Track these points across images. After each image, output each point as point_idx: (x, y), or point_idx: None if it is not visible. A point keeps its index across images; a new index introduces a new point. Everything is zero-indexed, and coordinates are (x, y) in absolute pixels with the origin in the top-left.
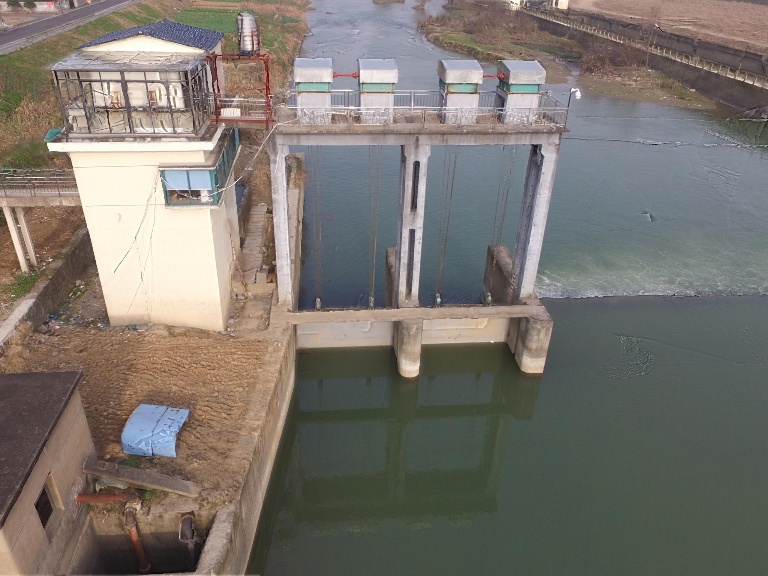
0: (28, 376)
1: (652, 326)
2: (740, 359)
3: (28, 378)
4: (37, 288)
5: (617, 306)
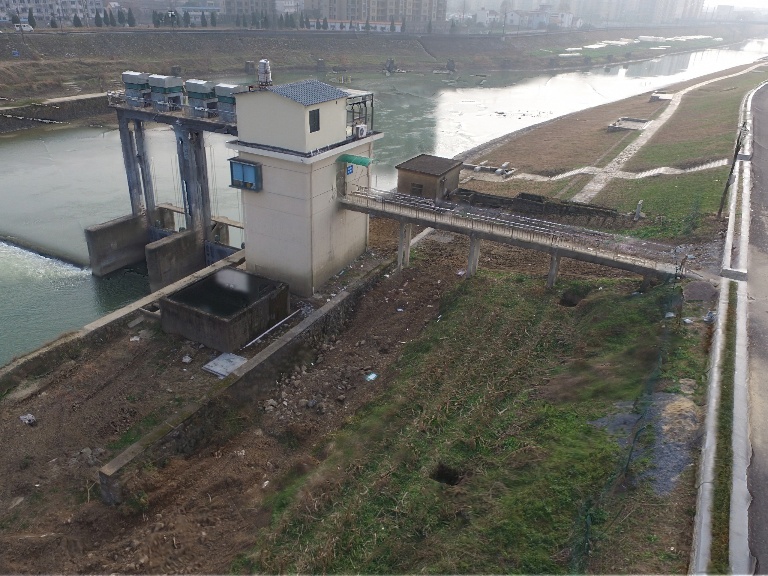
0: (413, 168)
1: (65, 237)
2: (73, 219)
3: (413, 168)
4: (403, 250)
5: (51, 246)
